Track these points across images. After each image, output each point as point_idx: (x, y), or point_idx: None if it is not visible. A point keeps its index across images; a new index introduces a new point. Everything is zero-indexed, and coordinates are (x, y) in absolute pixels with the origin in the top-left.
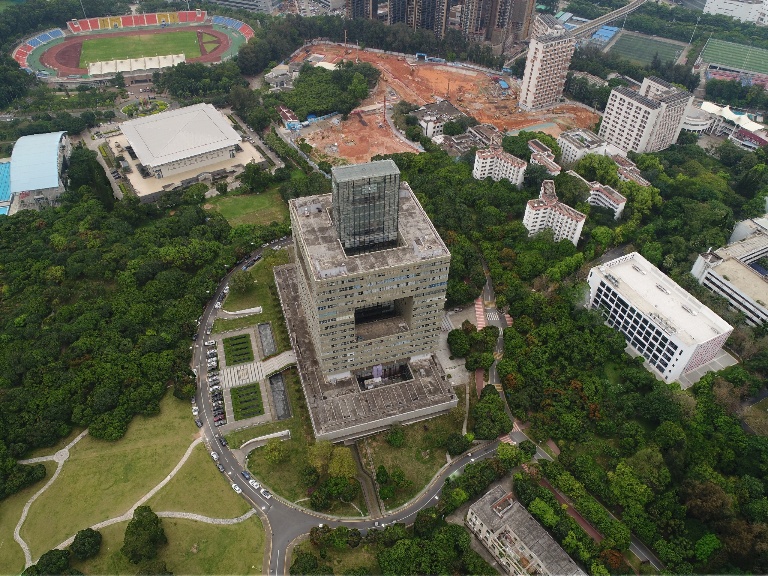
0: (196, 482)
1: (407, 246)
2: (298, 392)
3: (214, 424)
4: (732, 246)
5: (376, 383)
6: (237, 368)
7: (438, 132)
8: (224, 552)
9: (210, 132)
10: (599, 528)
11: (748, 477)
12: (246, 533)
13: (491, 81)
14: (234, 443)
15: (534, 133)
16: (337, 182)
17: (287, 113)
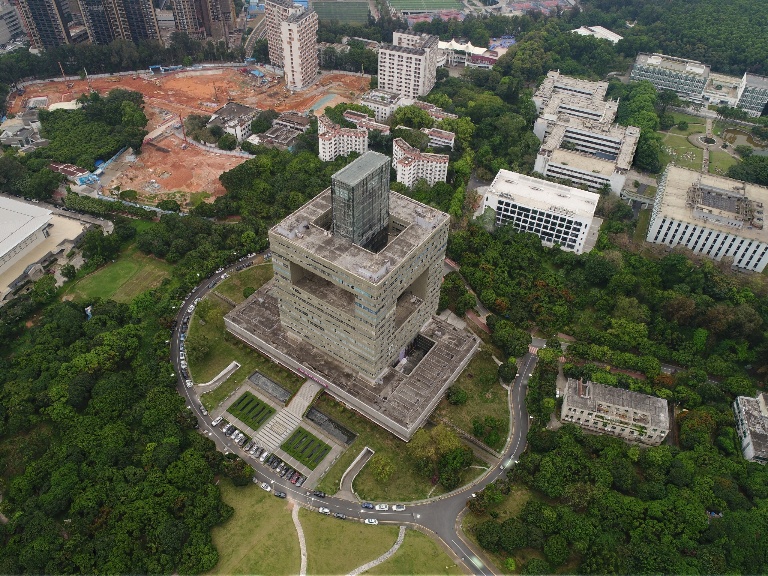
0: (332, 542)
1: (412, 224)
2: (343, 412)
3: (296, 486)
4: (547, 140)
5: (404, 365)
6: (267, 427)
7: (245, 134)
8: (413, 575)
9: (4, 218)
10: (638, 368)
11: (677, 286)
12: (415, 548)
13: (242, 74)
14: (330, 489)
15: (342, 105)
16: (352, 186)
17: (68, 168)
